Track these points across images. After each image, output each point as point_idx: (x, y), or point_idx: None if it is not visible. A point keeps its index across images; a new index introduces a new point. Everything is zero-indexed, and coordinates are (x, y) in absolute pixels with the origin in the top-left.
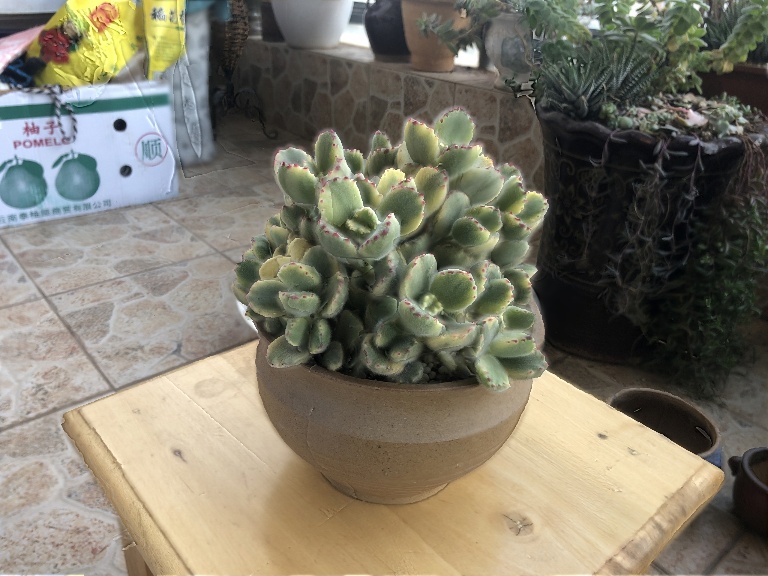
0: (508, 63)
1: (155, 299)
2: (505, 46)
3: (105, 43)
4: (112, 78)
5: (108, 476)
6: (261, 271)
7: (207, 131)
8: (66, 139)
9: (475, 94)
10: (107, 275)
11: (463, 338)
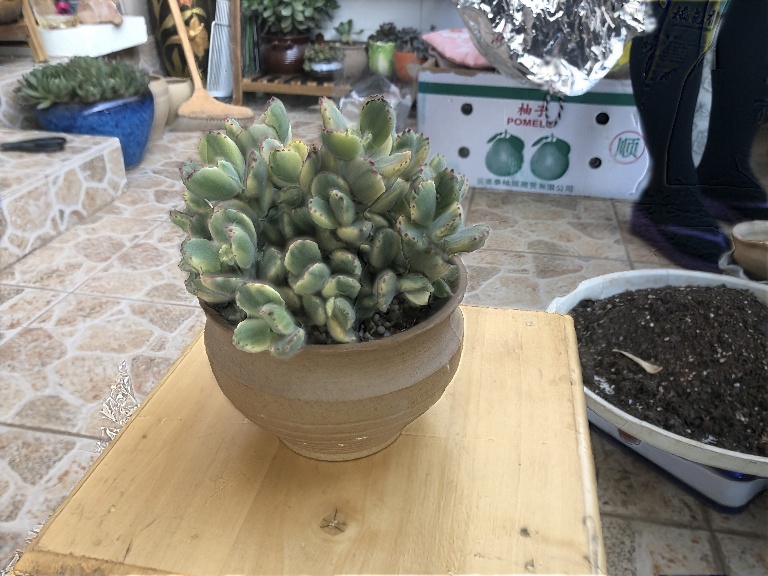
0: None
1: (534, 279)
2: None
3: (616, 39)
4: (609, 73)
5: None
6: None
7: (716, 142)
8: (548, 123)
9: None
10: (517, 247)
11: (207, 283)
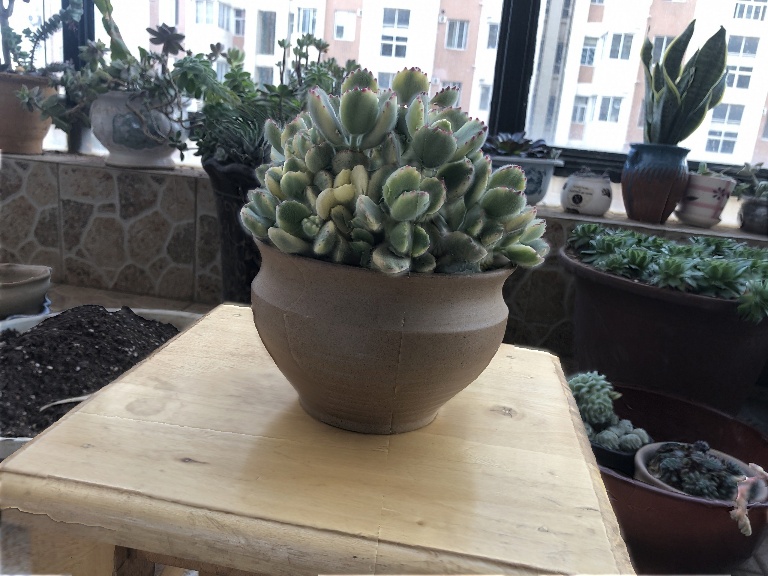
0: (121, 140)
1: None
2: (116, 123)
3: None
4: None
5: (125, 508)
6: (320, 202)
7: None
8: None
9: (85, 173)
10: None
11: None
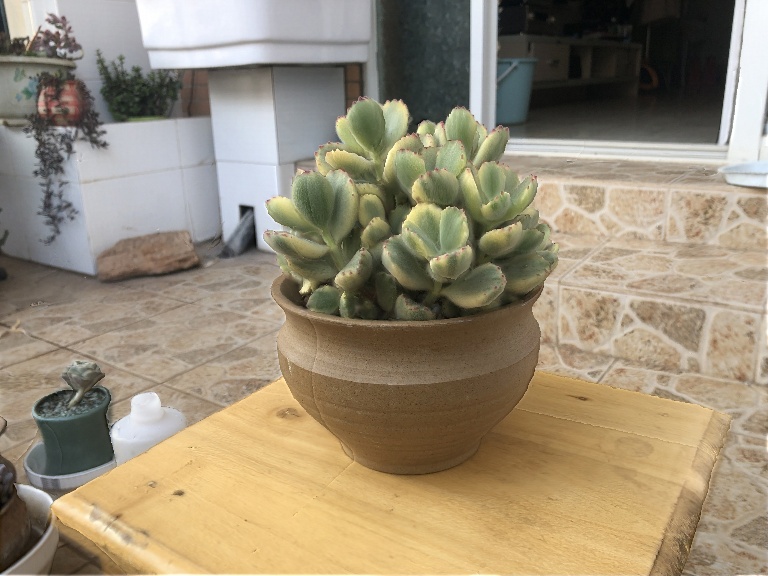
0: None
1: None
2: None
3: None
4: None
5: None
6: None
7: None
8: None
9: None
10: None
11: None
